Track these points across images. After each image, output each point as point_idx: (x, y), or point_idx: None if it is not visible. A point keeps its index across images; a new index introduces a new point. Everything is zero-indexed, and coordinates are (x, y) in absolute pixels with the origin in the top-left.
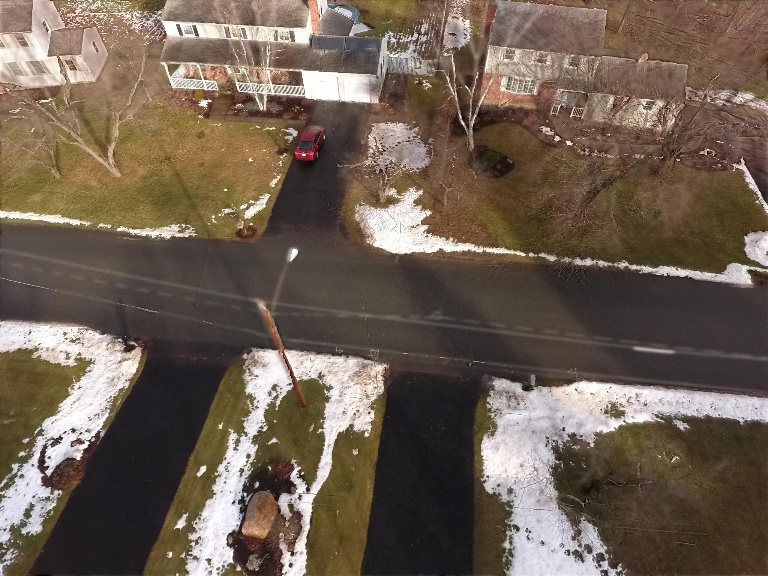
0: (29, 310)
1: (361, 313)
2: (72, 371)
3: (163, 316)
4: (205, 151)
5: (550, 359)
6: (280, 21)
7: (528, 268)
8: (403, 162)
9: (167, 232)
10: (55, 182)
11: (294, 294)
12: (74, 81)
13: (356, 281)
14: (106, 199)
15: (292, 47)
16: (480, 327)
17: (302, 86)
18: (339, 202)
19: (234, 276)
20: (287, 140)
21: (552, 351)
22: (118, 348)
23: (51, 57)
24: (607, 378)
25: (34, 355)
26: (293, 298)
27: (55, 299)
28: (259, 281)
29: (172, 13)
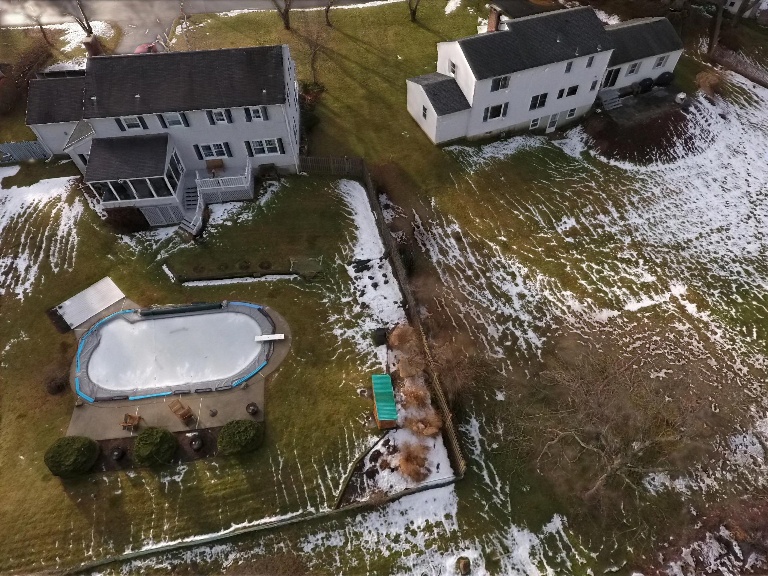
0: None
1: (117, 1)
2: None
3: None
4: None
5: (27, 1)
6: None
7: (12, 24)
8: (69, 65)
9: (233, 11)
10: None
11: (152, 2)
12: None
13: (118, 9)
14: None
15: None
16: (56, 3)
17: None
18: (125, 37)
19: (186, 3)
20: None
21: (24, 3)
22: None
23: None
24: (4, 0)
25: None
26: (152, 1)
27: None
28: (172, 3)
29: None
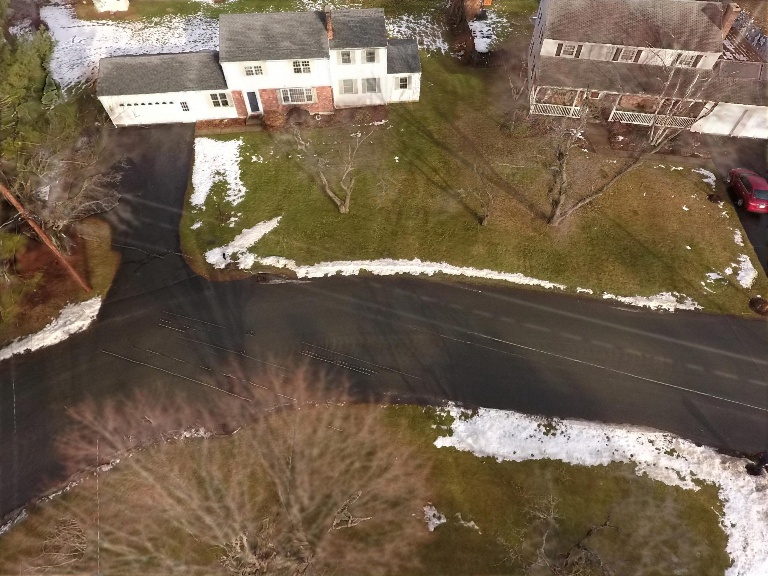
0: (583, 405)
1: None
2: (704, 499)
3: (752, 422)
4: (625, 195)
5: None
6: (689, 44)
7: None
8: None
9: (668, 303)
10: (486, 230)
11: None
12: (397, 100)
13: None
14: (561, 255)
15: (693, 73)
16: None
17: (693, 118)
18: None
19: None
20: (709, 184)
21: None
22: (741, 469)
23: (390, 74)
24: None
25: (638, 471)
26: None
27: (604, 391)
28: None
29: (556, 31)
